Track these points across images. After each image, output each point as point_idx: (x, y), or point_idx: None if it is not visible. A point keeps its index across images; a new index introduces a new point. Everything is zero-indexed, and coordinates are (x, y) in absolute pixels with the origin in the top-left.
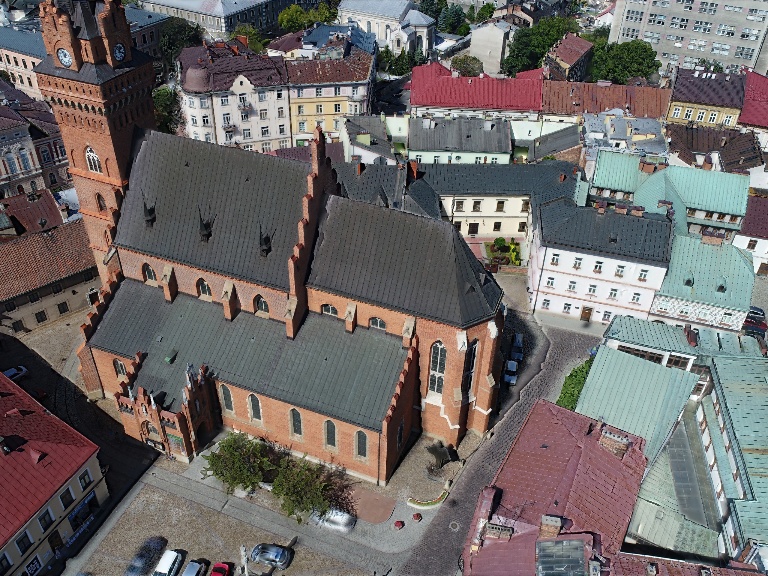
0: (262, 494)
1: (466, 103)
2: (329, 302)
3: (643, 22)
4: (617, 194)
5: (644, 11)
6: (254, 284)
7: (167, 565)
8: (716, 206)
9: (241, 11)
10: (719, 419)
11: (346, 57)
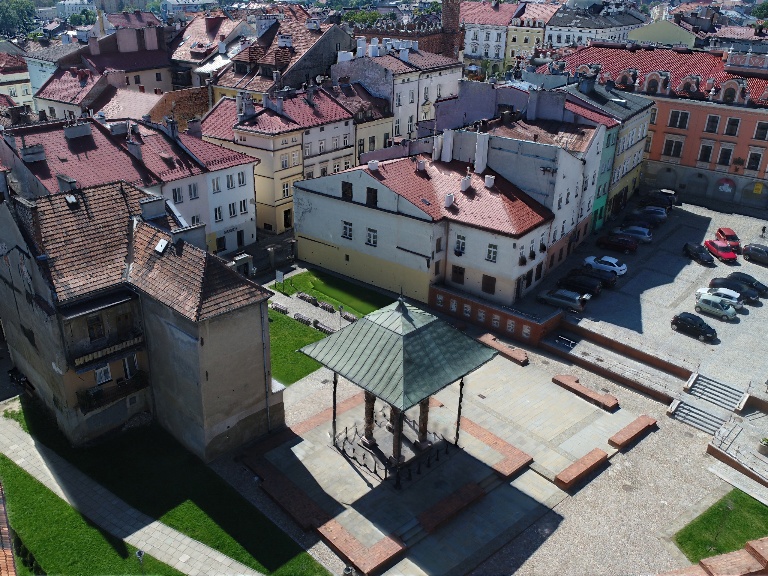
0: None
1: None
2: None
3: None
4: None
5: None
6: None
7: None
8: None
9: None
10: None
11: None
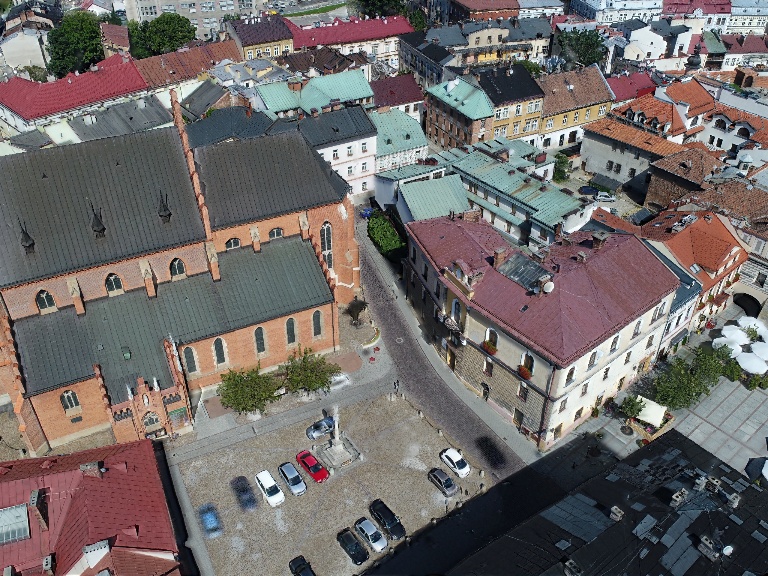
0: (270, 407)
1: (80, 101)
2: (233, 236)
3: None
4: (289, 113)
5: None
6: (170, 250)
7: (270, 480)
8: (355, 95)
9: None
10: (479, 195)
11: None
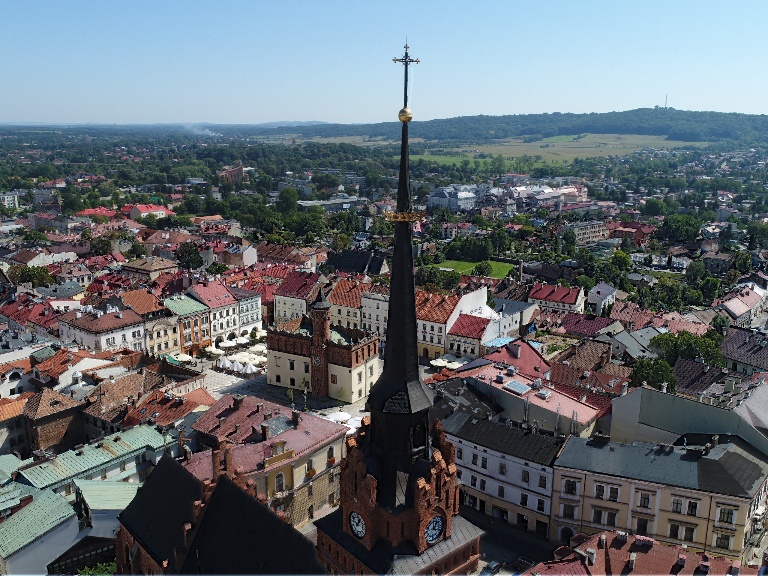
0: None
1: None
2: None
3: None
4: None
5: None
6: None
7: None
8: None
9: None
10: None
11: None
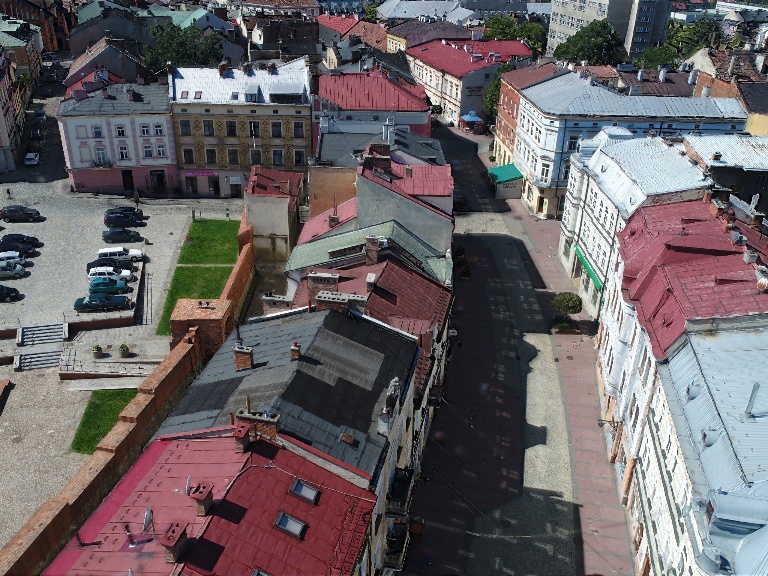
0: None
1: None
2: None
3: (557, 23)
4: None
5: None
6: None
7: None
8: None
9: (407, 18)
10: None
11: None
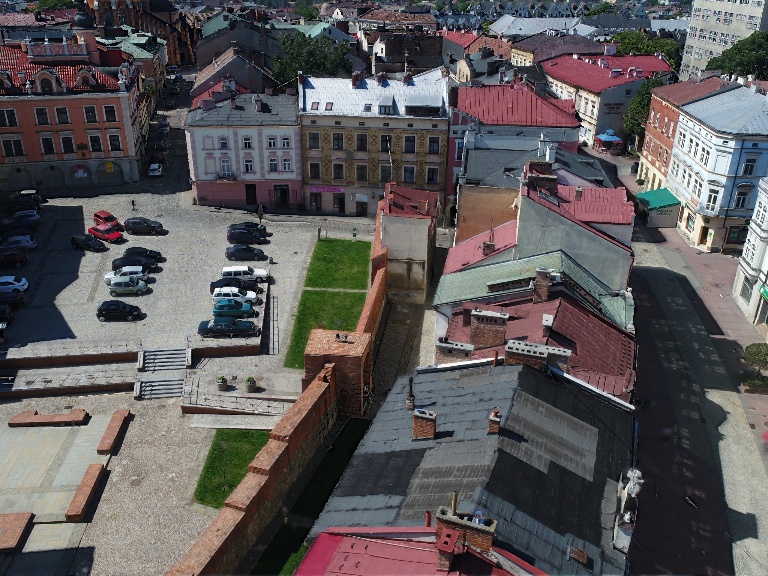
0: None
1: None
2: None
3: (695, 38)
4: None
5: (697, 26)
6: None
7: None
8: None
9: (522, 35)
10: None
11: (406, 13)
